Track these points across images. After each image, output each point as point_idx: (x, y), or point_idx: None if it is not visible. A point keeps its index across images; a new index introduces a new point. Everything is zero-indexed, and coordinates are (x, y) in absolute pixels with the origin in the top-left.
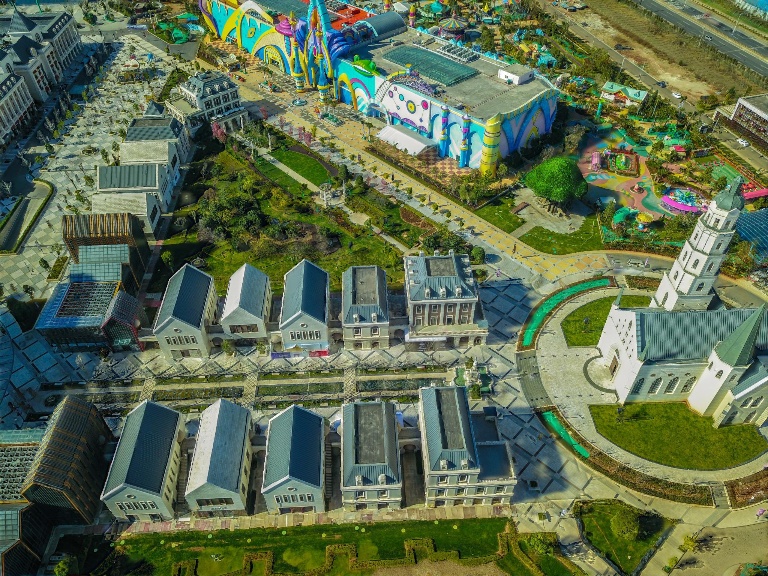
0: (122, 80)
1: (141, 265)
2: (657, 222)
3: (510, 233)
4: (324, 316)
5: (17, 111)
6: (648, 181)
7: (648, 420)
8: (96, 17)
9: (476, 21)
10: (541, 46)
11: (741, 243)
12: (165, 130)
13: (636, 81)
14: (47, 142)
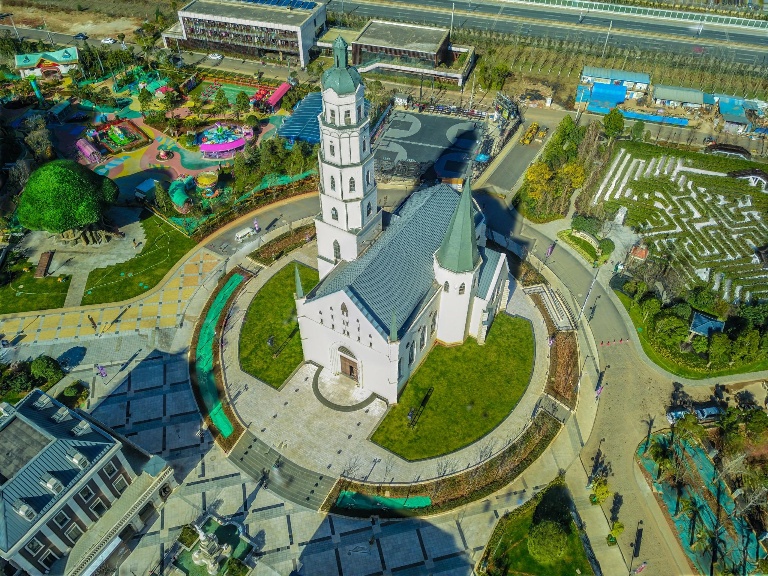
0: None
1: None
2: (220, 177)
3: (63, 305)
4: None
5: None
6: (167, 141)
7: (432, 395)
8: None
9: None
10: None
11: (315, 148)
12: None
13: (49, 44)
14: None
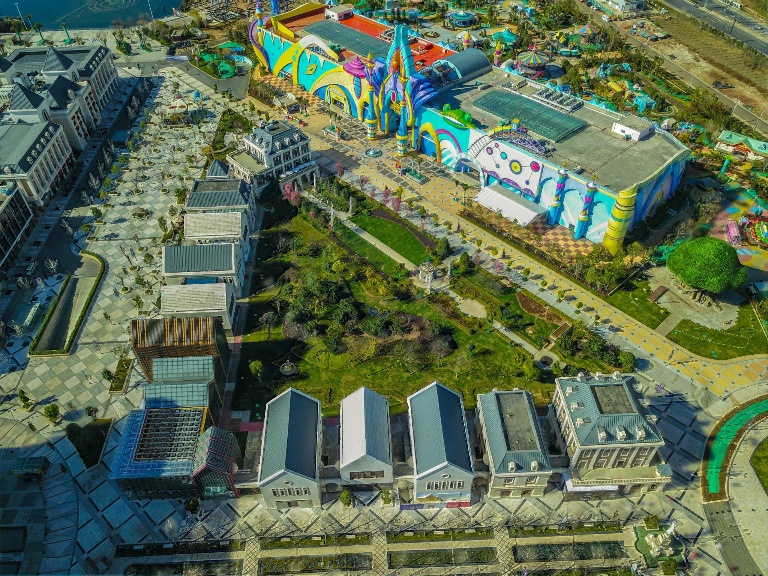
0: (168, 123)
1: (223, 374)
2: None
3: (655, 329)
4: (469, 462)
5: (55, 165)
6: None
7: None
8: (130, 46)
9: (551, 52)
10: (632, 84)
11: None
12: (233, 195)
13: (750, 128)
14: (91, 202)
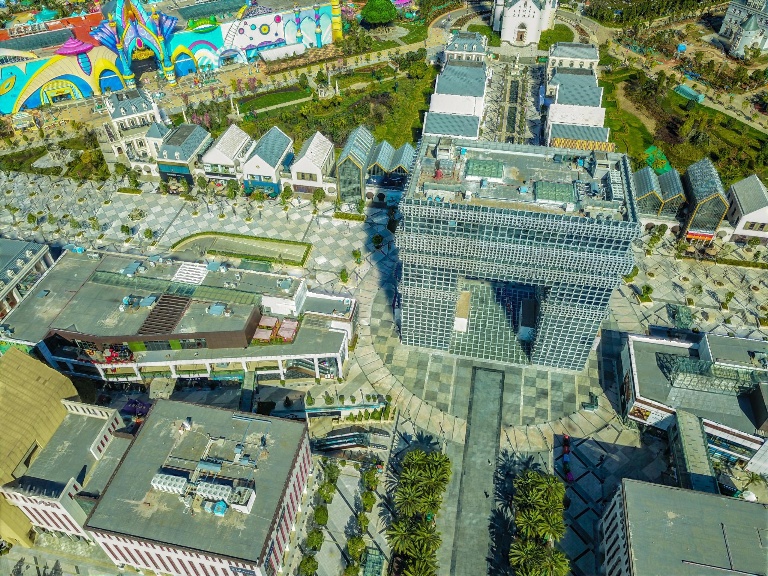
0: None
1: None
2: None
3: (401, 45)
4: None
5: None
6: None
7: None
8: None
9: None
10: None
11: None
12: (199, 131)
13: None
14: None
